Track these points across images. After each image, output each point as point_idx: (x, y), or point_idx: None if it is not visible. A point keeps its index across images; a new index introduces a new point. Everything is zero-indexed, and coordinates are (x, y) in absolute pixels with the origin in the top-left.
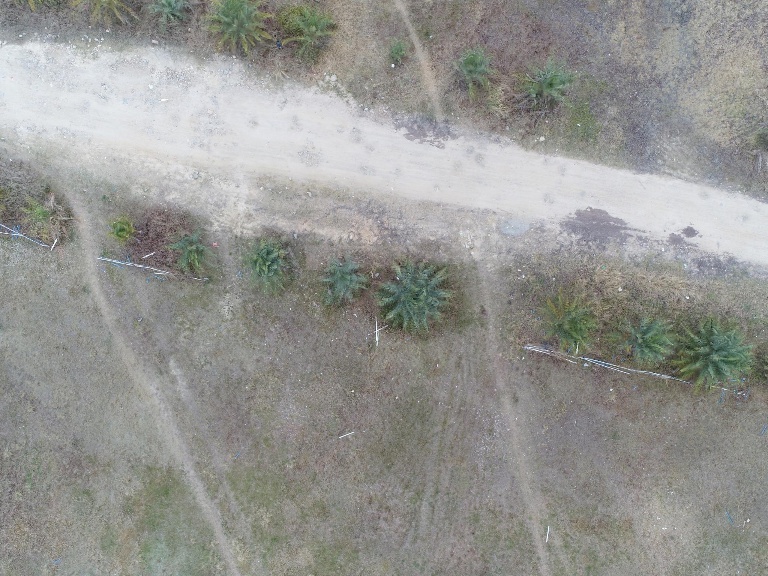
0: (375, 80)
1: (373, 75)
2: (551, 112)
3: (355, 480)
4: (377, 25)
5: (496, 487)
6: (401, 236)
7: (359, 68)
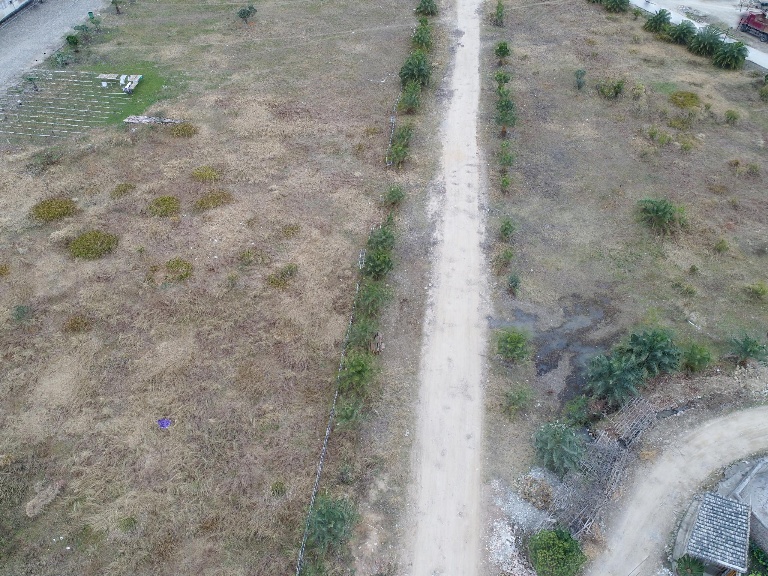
0: (491, 5)
1: (492, 5)
2: (493, 26)
3: (367, 8)
4: (508, 5)
5: (368, 25)
6: (445, 10)
7: (493, 3)
